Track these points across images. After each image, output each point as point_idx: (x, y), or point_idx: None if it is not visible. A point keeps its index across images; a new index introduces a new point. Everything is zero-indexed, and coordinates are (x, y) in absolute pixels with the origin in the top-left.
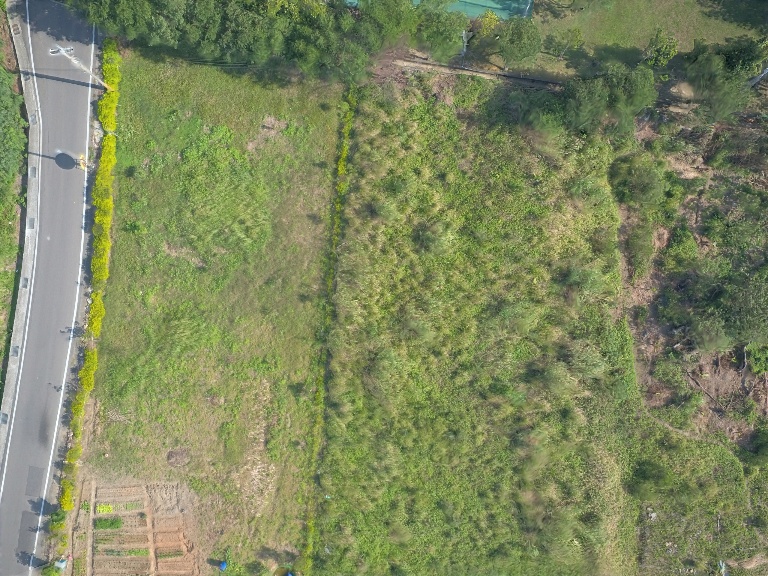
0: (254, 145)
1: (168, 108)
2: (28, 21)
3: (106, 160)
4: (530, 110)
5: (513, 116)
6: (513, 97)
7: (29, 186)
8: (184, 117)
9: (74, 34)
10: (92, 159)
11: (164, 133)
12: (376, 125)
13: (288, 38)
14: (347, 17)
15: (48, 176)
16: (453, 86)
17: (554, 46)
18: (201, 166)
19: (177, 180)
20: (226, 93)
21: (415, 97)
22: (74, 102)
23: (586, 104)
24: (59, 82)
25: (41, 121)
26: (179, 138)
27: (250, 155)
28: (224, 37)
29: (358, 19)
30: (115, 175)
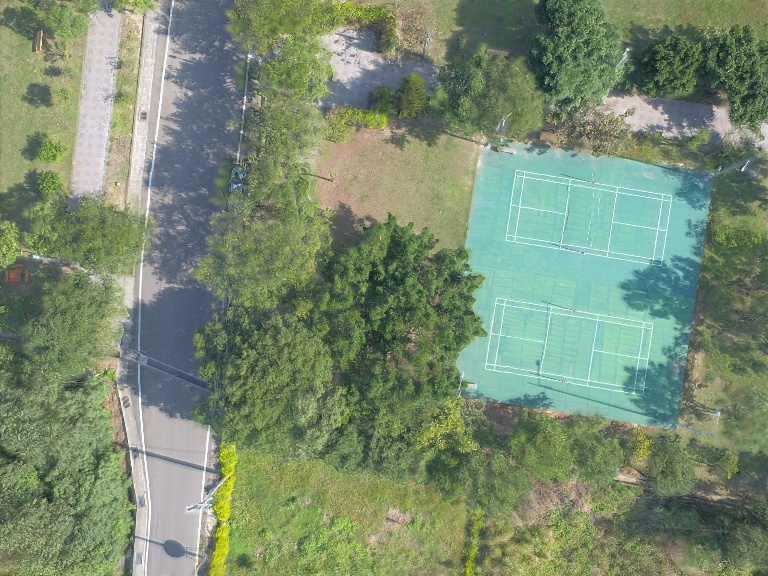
0: (377, 538)
1: (287, 494)
2: (140, 394)
3: (220, 554)
4: (676, 536)
5: (653, 527)
6: (657, 516)
7: (134, 572)
8: (303, 504)
9: (189, 412)
10: (204, 548)
11: (281, 521)
12: (508, 528)
13: (430, 463)
14: (500, 461)
15: (155, 563)
16: (592, 492)
17: (698, 452)
18: (320, 559)
19: (294, 573)
20: (349, 481)
21: (551, 502)
22: (187, 485)
23: (746, 563)
24: (171, 463)
25: (150, 503)
26: (297, 527)
27: (372, 549)
28: (364, 467)
29: (512, 466)
30: (227, 563)
